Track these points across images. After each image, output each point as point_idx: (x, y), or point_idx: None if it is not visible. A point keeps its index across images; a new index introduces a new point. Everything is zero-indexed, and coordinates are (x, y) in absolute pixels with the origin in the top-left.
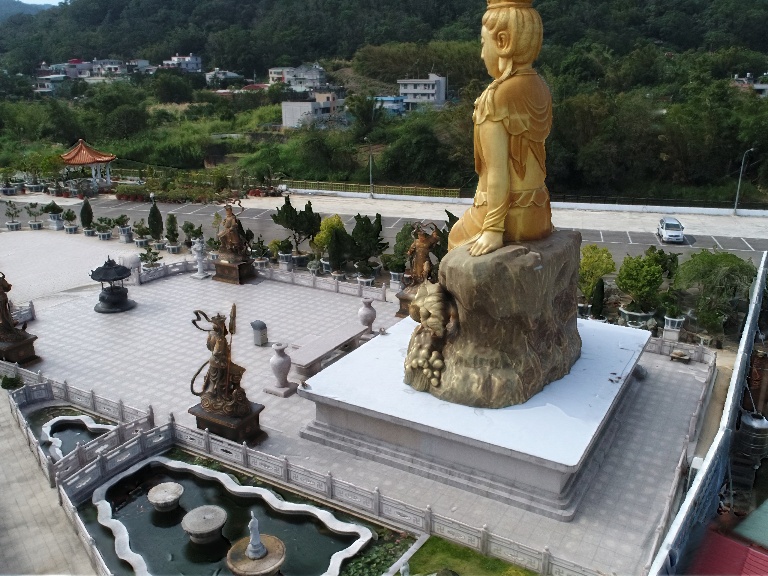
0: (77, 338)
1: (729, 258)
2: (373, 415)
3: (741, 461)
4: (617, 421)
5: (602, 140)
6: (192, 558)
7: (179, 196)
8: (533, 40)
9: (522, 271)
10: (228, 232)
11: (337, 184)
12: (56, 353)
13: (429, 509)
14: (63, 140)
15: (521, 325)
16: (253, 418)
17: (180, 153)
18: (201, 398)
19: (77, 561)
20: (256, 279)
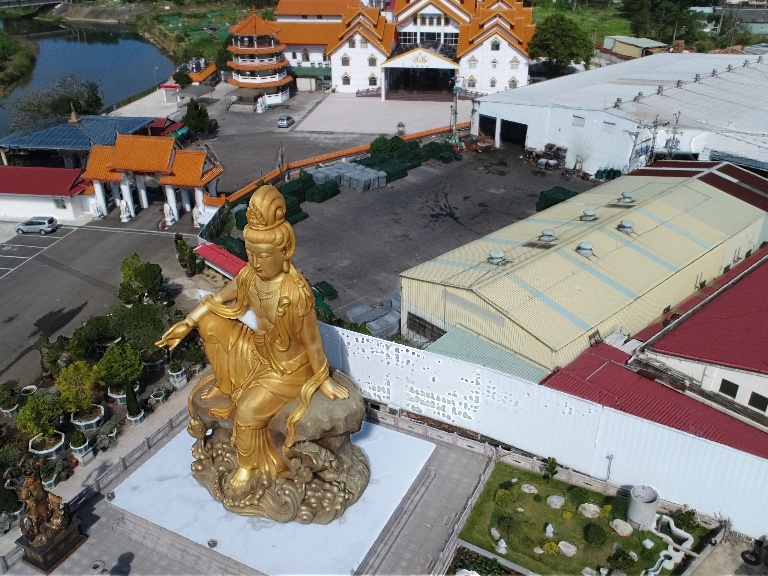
0: None
1: (147, 309)
2: None
3: None
4: None
5: None
6: None
7: None
8: None
9: None
10: None
11: None
12: None
13: None
14: None
15: None
16: None
17: None
18: None
19: None
20: None
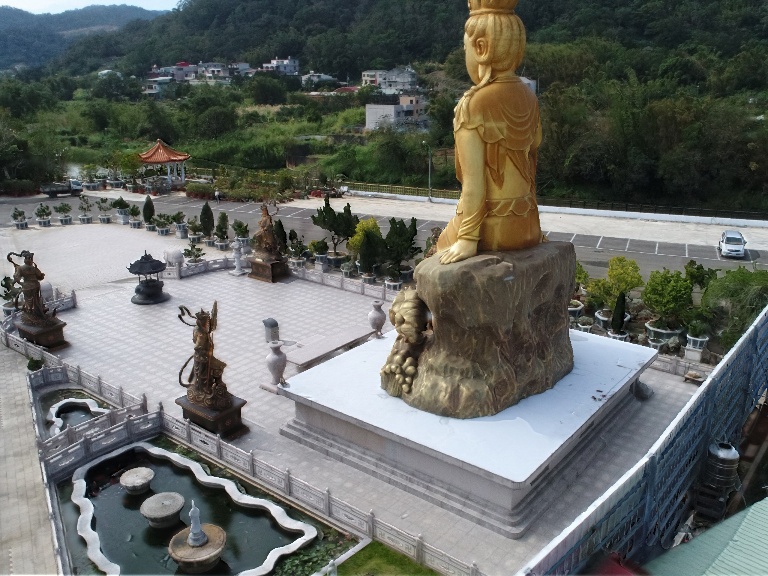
0: (107, 326)
1: (765, 276)
2: (341, 417)
3: (708, 492)
4: (601, 441)
5: (685, 147)
6: (149, 541)
7: (243, 195)
8: (512, 47)
9: (490, 281)
10: (263, 231)
11: (396, 187)
12: (85, 339)
13: (371, 514)
14: None
15: (492, 336)
16: (234, 412)
17: (264, 153)
18: (187, 390)
19: (40, 533)
20: (289, 278)
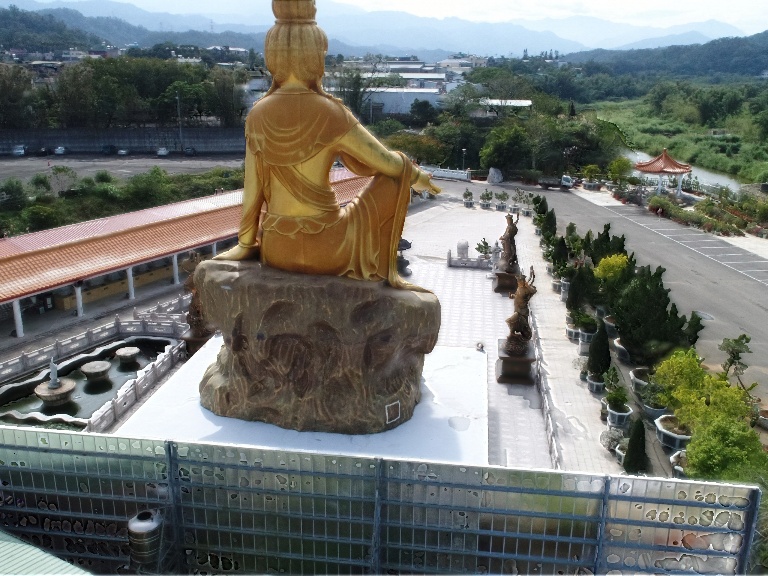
0: None
1: None
2: None
3: None
4: None
5: None
6: None
7: (692, 218)
8: (278, 58)
9: (211, 283)
10: None
11: None
12: None
13: (88, 422)
14: None
15: None
16: (204, 343)
17: None
18: None
19: None
20: None
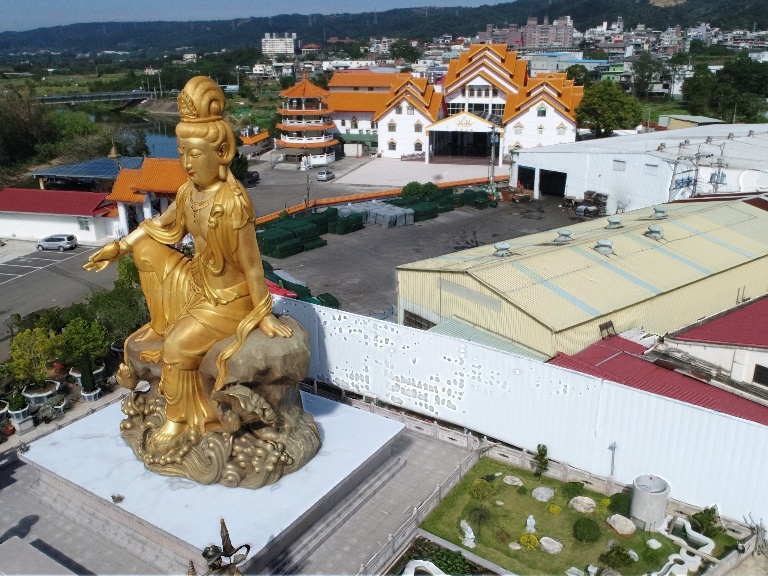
0: None
1: (126, 291)
2: (307, 515)
3: None
4: None
5: None
6: None
7: None
8: None
9: None
10: None
11: None
12: None
13: (417, 510)
14: None
15: None
16: None
17: None
18: None
19: None
20: None
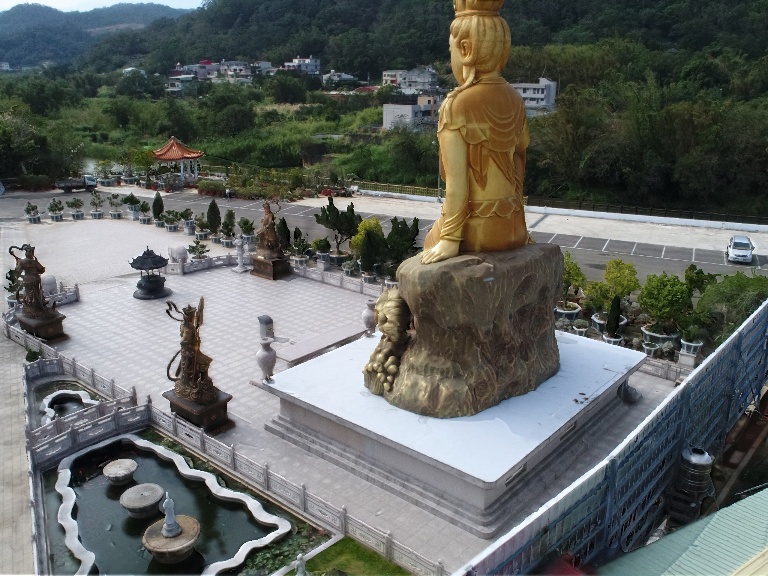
0: (107, 320)
1: (762, 282)
2: (321, 414)
3: (680, 497)
4: (583, 443)
5: (702, 151)
6: (127, 530)
7: (253, 193)
8: (496, 48)
9: (469, 282)
10: (265, 229)
11: (406, 187)
12: (84, 332)
13: (343, 510)
14: (177, 136)
15: (472, 336)
16: (219, 407)
17: (280, 152)
18: (175, 383)
19: (22, 520)
20: (290, 276)
